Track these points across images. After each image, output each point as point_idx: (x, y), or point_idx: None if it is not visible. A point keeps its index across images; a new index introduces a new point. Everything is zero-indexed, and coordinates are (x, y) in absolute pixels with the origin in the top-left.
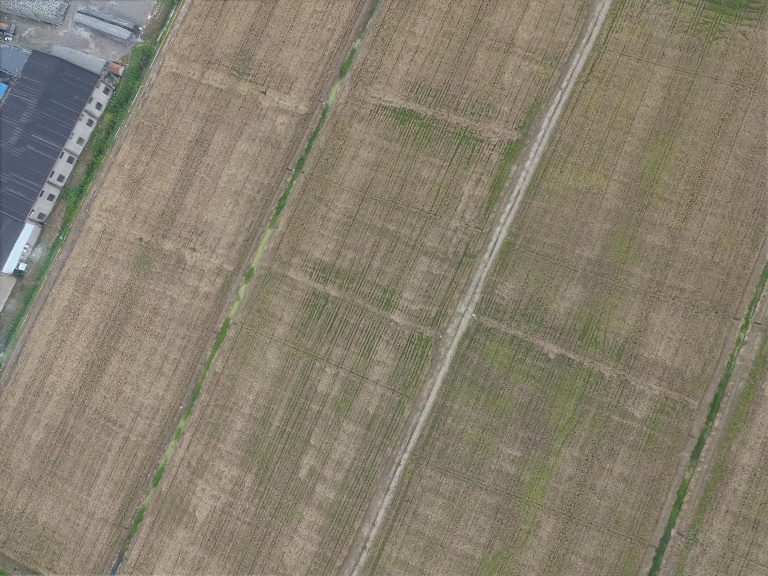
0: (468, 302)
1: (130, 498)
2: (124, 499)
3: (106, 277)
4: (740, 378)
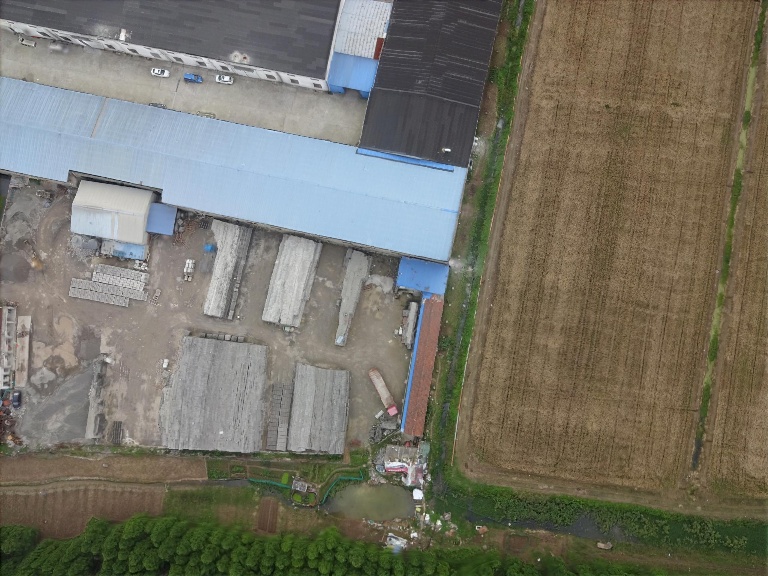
0: None
1: (691, 379)
2: (685, 381)
3: (579, 155)
4: None
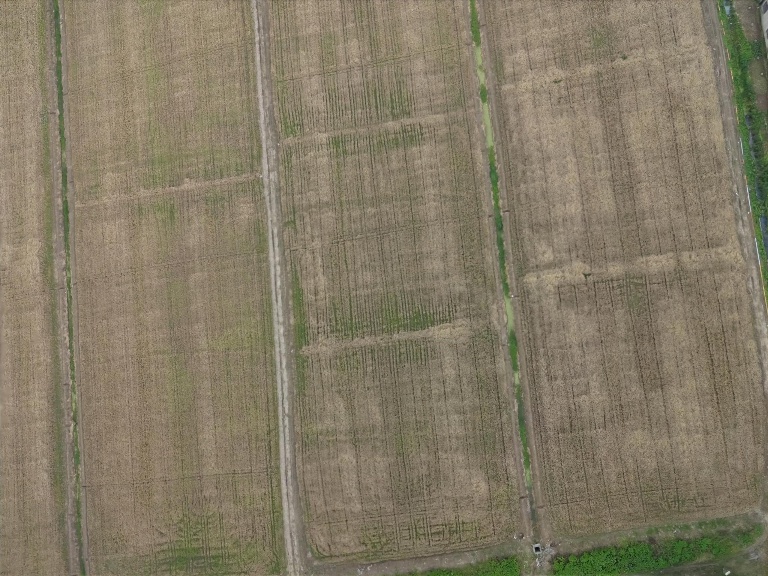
0: (271, 184)
1: None
2: None
3: (637, 1)
4: (57, 241)
